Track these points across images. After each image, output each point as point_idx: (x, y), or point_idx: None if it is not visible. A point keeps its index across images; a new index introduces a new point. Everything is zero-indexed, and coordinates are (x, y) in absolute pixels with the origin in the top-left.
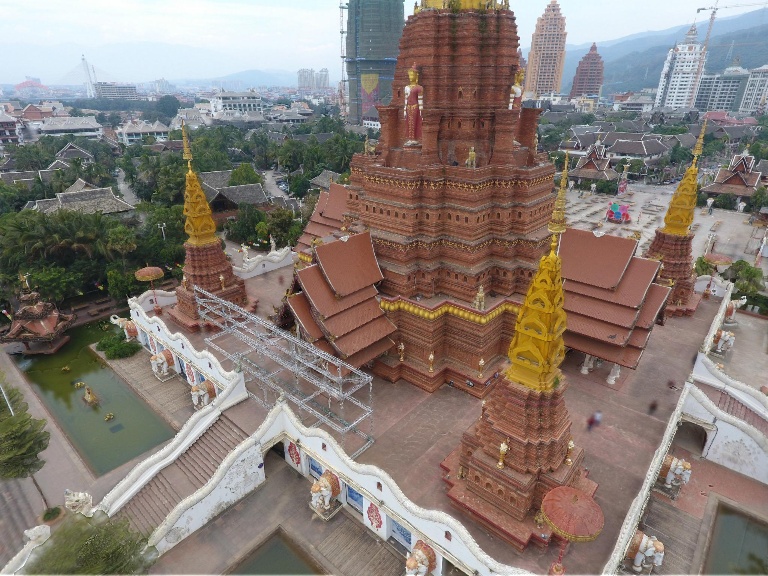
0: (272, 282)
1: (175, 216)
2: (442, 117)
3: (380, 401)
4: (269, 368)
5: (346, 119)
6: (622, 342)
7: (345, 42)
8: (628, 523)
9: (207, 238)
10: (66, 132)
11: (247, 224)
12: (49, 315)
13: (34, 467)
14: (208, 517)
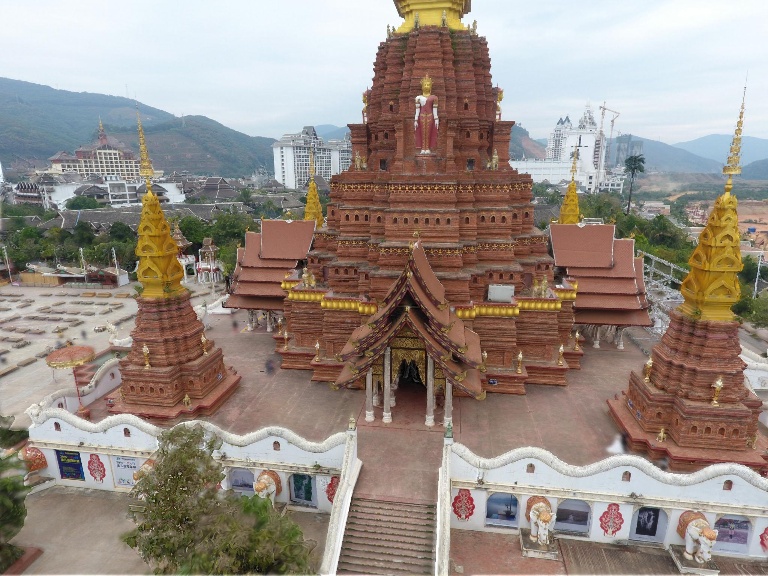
0: (542, 445)
1: None
2: None
3: None
4: (642, 357)
5: None
6: None
7: None
8: None
9: None
10: None
11: None
12: None
13: None
14: None
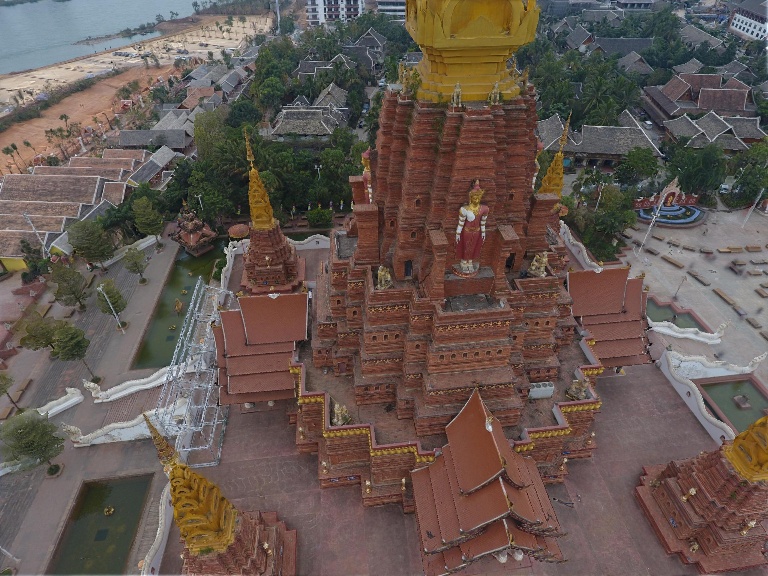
0: None
1: (332, 160)
2: (383, 214)
3: (263, 433)
4: None
5: None
6: (428, 548)
7: None
8: None
9: (263, 224)
10: (394, 4)
11: None
12: (198, 231)
13: (80, 357)
14: (135, 437)
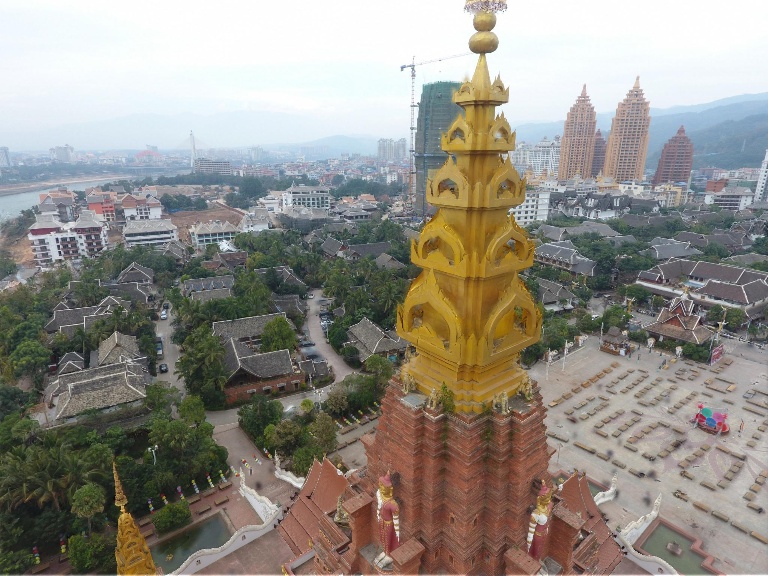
0: (246, 573)
1: (170, 434)
2: None
3: None
4: None
5: (413, 206)
6: None
7: (415, 137)
8: None
9: None
10: (144, 235)
11: (257, 422)
12: None
13: None
14: None
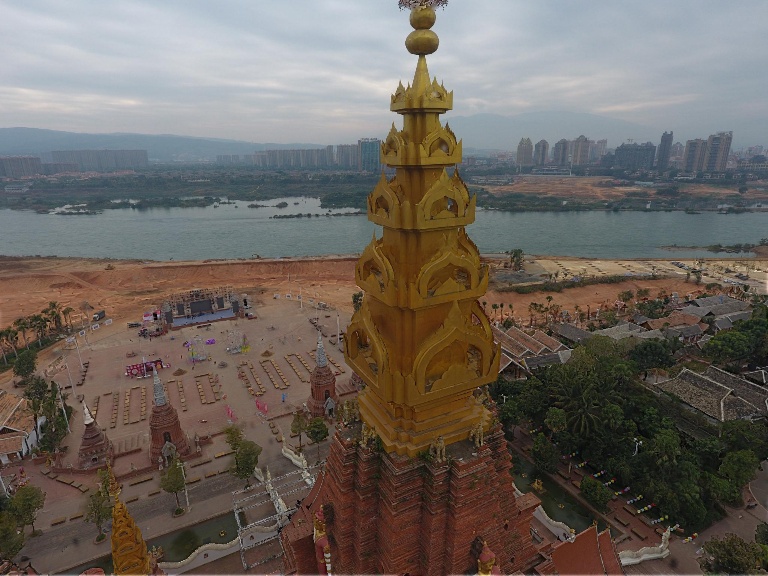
0: None
1: None
2: None
3: None
4: None
5: None
6: None
7: None
8: None
9: None
10: None
11: None
12: None
13: (316, 441)
14: None
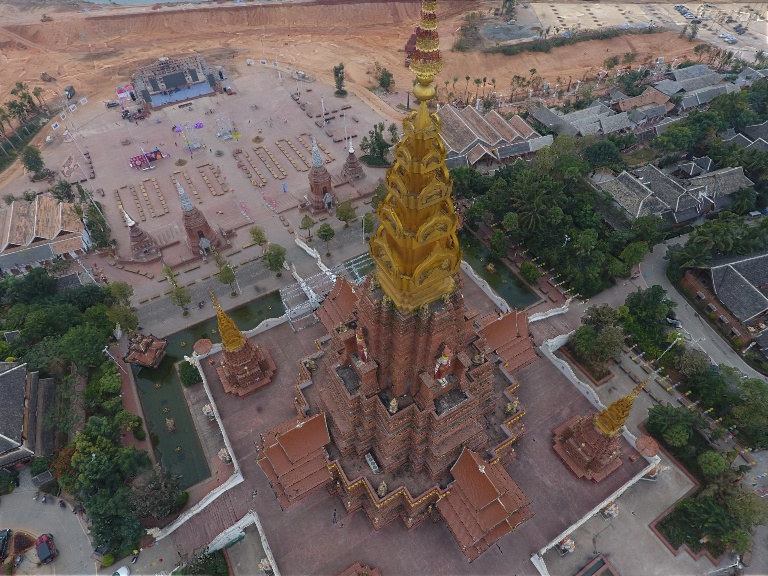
0: None
1: None
2: None
3: None
4: None
5: None
6: (263, 435)
7: None
8: (204, 382)
9: None
10: None
11: (633, 300)
12: None
13: (326, 240)
14: None
